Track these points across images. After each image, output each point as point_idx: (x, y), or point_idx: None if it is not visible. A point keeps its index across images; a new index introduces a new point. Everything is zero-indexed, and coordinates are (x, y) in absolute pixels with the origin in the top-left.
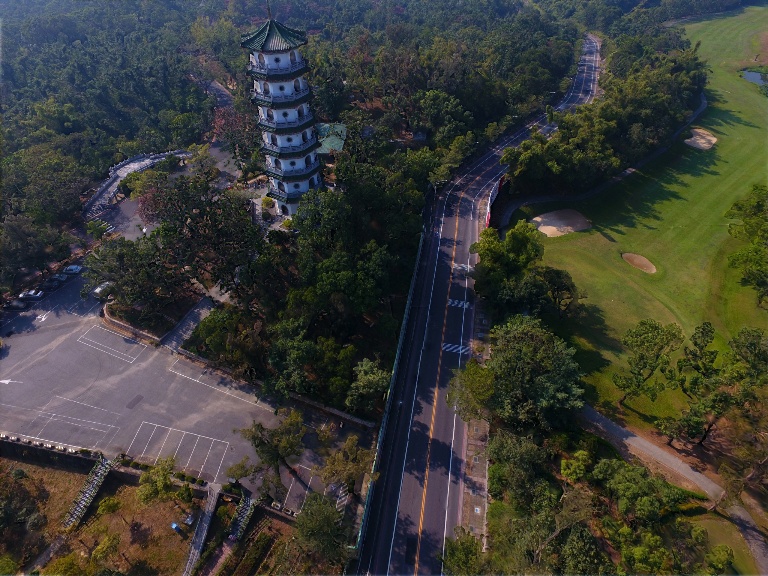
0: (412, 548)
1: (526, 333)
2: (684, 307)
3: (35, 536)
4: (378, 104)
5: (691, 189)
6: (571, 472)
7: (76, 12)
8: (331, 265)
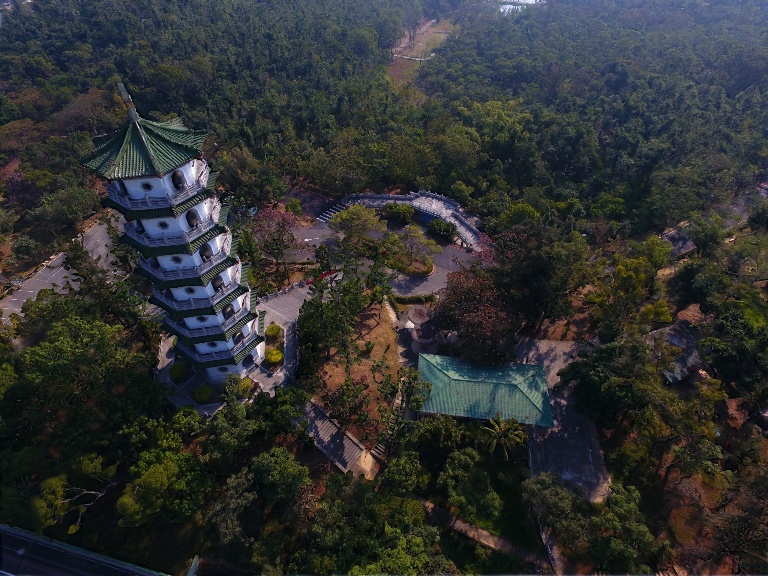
0: None
1: None
2: None
3: None
4: None
5: None
6: None
7: None
8: None
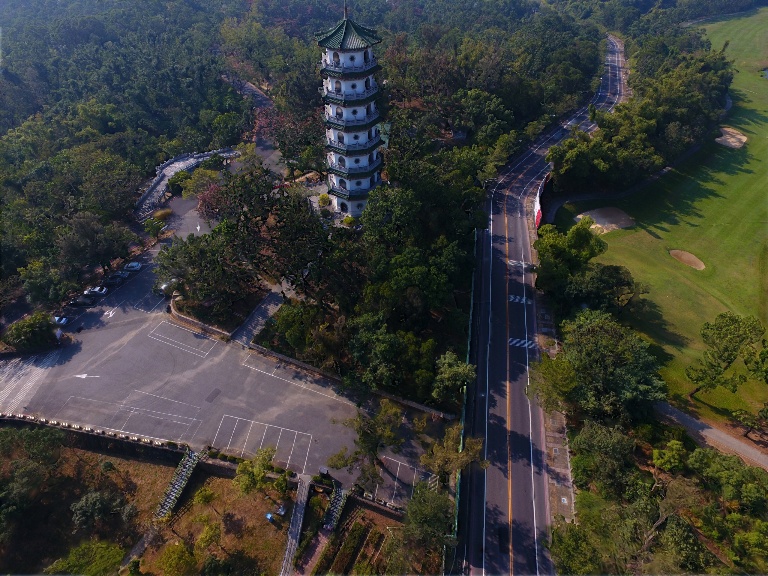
0: (504, 537)
1: (600, 327)
2: (738, 302)
3: (127, 527)
4: (416, 104)
5: (728, 187)
6: (665, 461)
7: (103, 14)
8: (404, 260)
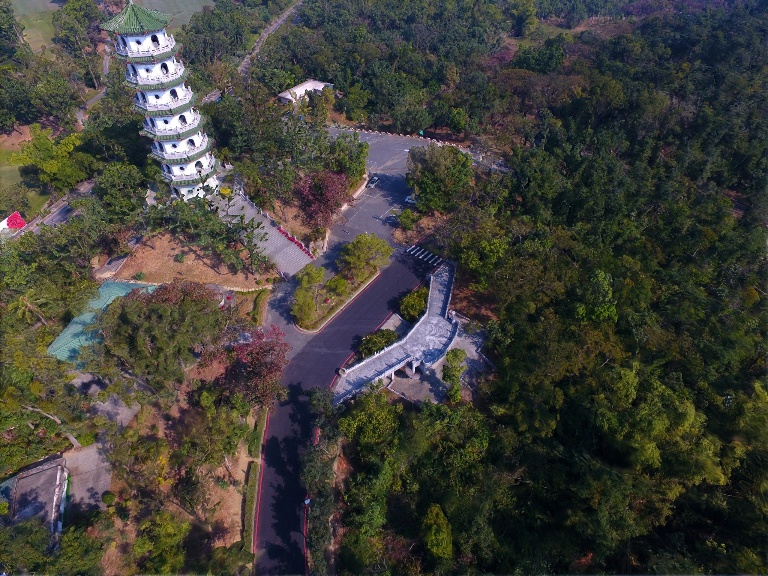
0: None
1: None
2: None
3: None
4: None
5: None
6: None
7: None
8: None
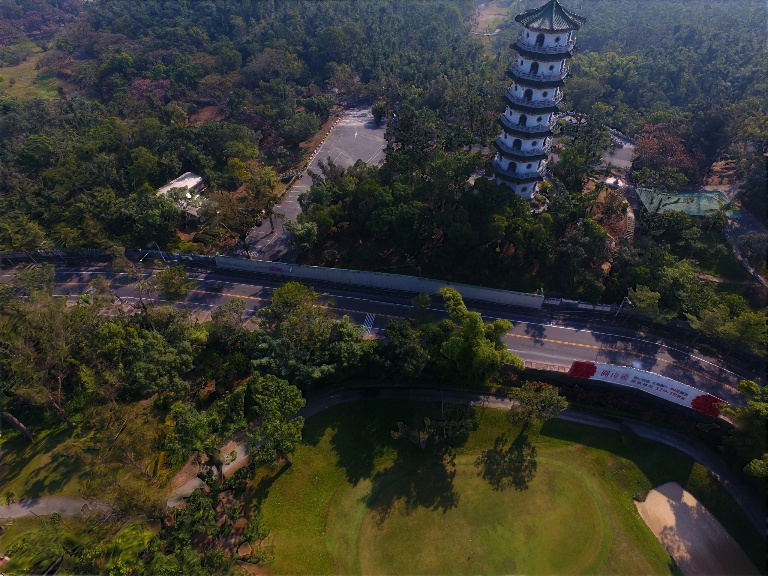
0: (215, 290)
1: (335, 330)
2: None
3: None
4: None
5: None
6: None
7: None
8: None
